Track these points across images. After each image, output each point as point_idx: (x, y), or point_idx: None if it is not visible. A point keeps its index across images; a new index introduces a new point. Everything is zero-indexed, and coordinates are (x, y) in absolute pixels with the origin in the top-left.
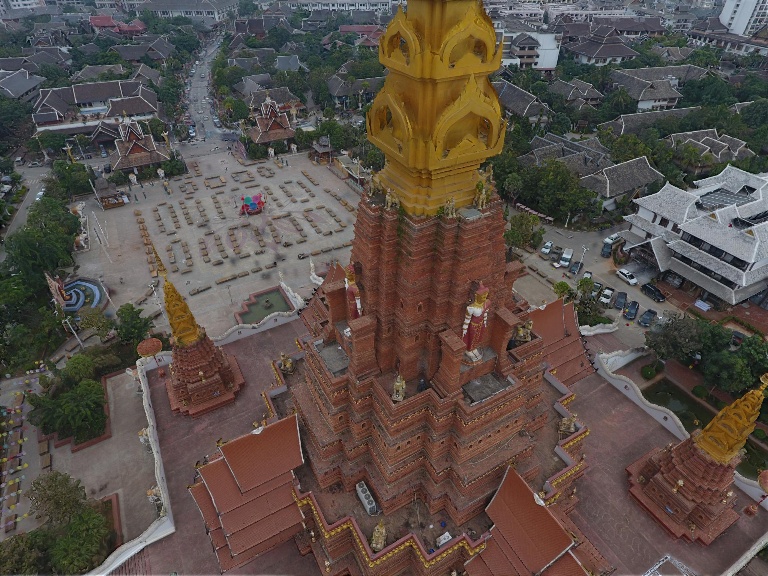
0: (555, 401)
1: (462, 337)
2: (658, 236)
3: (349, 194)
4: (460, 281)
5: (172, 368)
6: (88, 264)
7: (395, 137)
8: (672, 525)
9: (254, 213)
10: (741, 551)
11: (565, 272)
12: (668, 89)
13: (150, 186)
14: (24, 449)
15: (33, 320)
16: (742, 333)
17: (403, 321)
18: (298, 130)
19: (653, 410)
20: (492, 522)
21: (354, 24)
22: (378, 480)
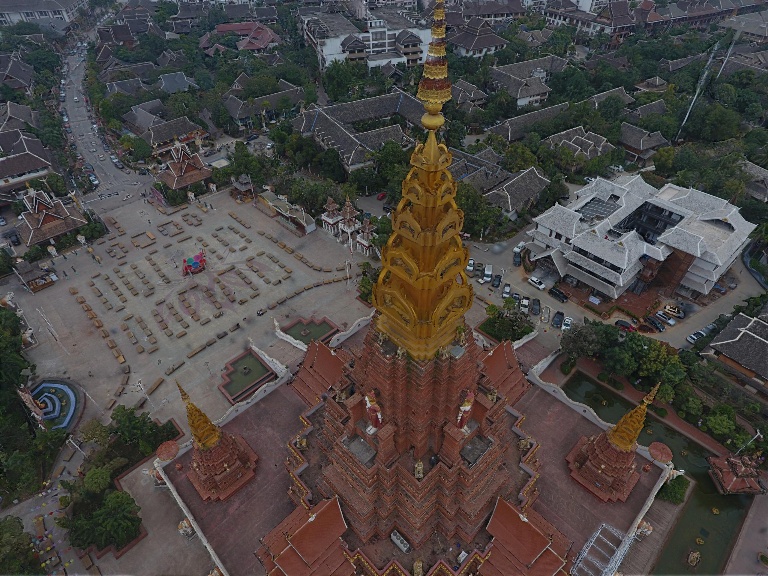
0: (512, 424)
1: (457, 423)
2: (555, 248)
3: (284, 234)
4: (455, 394)
5: (197, 466)
6: (44, 361)
7: (396, 306)
8: (601, 494)
9: (198, 271)
10: (644, 499)
11: (489, 287)
12: (539, 85)
13: (73, 255)
14: (67, 568)
15: (18, 439)
16: (624, 321)
17: (416, 424)
18: (214, 170)
19: (575, 406)
20: (492, 536)
21: (230, 21)
22: (408, 528)
